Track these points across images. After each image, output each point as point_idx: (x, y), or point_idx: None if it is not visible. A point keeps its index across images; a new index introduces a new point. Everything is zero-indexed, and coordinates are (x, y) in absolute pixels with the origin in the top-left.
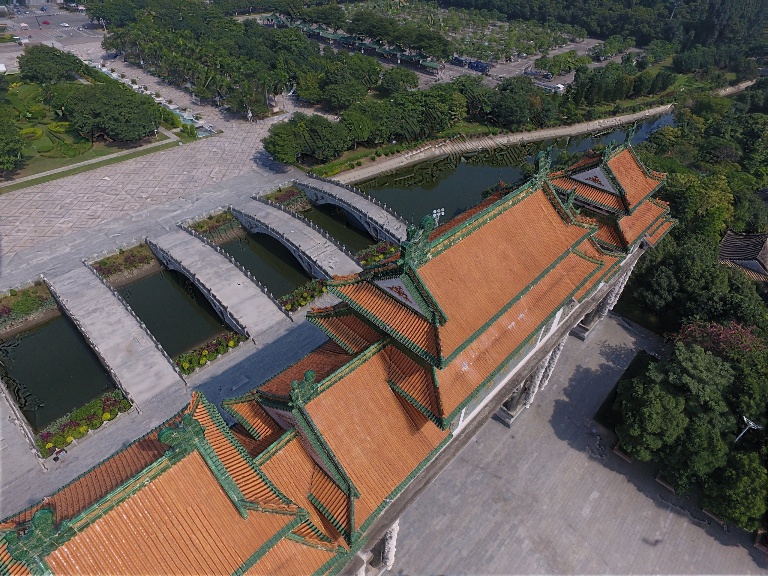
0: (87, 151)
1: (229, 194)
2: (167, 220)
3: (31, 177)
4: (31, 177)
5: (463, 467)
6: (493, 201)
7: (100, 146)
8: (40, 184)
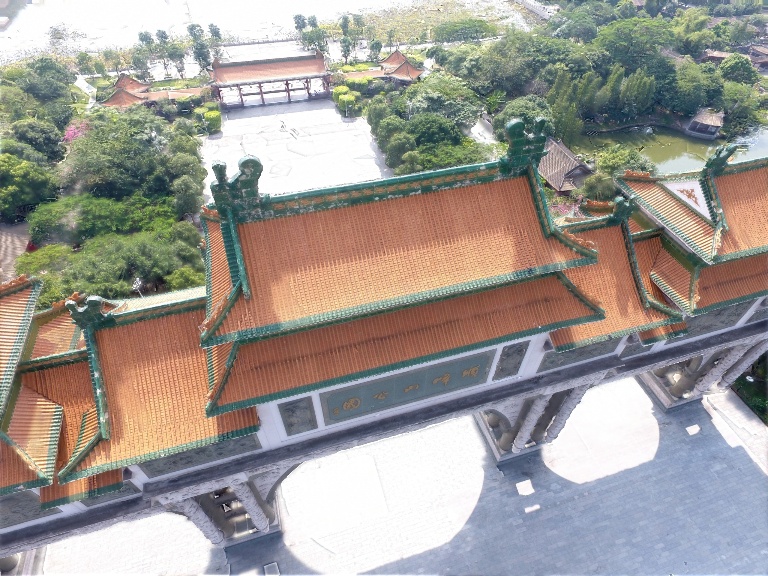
0: None
1: None
2: None
3: None
4: None
5: (354, 450)
6: (269, 298)
7: None
8: None
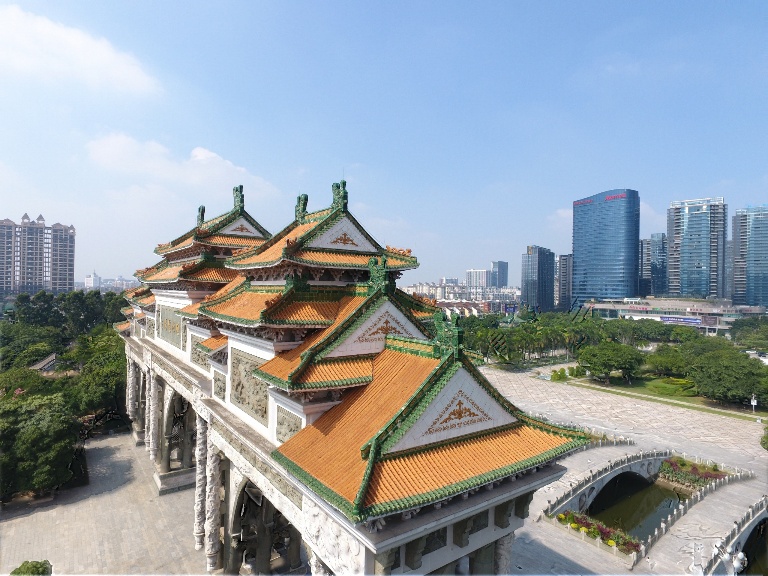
0: (678, 396)
1: (668, 445)
2: (586, 425)
3: (611, 389)
4: (611, 389)
5: None
6: None
7: (695, 399)
8: (605, 392)
